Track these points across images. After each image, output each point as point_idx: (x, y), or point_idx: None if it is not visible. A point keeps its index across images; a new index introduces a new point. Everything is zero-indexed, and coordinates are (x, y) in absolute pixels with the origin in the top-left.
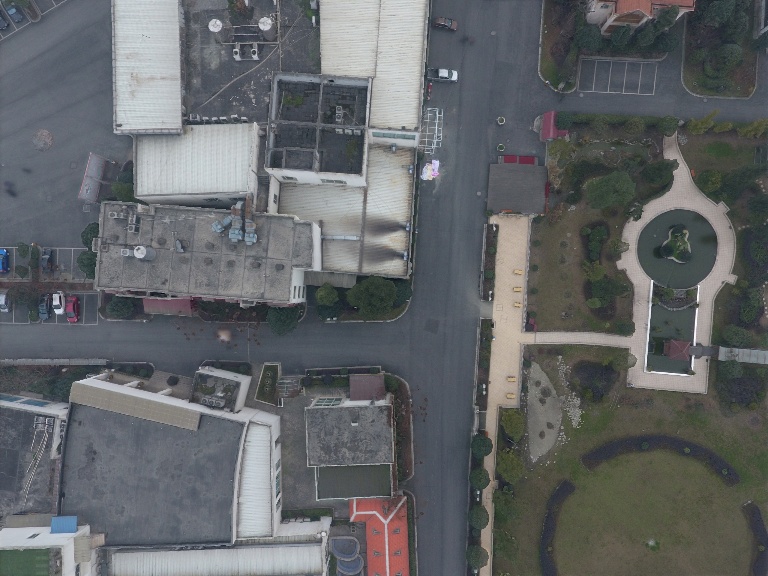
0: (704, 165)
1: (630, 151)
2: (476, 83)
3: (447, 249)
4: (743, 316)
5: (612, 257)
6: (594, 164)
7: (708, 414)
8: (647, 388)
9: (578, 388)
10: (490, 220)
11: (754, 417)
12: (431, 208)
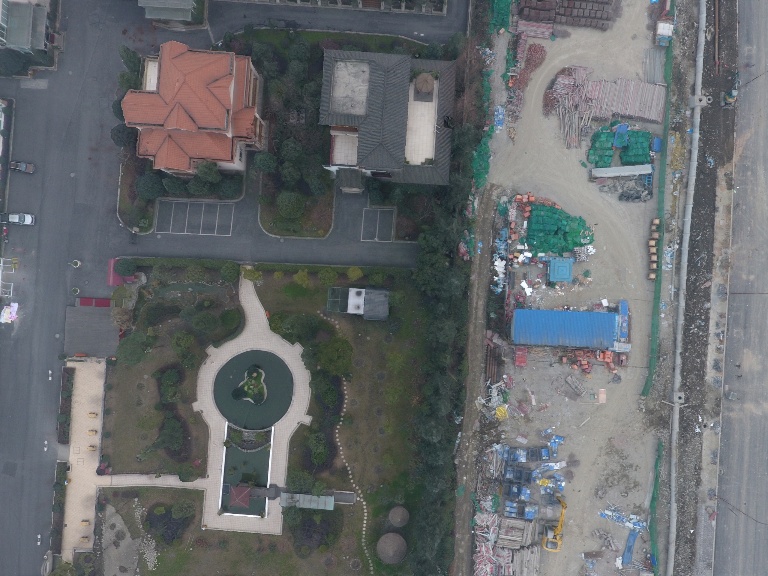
0: (281, 305)
1: (208, 292)
2: (55, 225)
3: (25, 392)
4: (313, 458)
5: (186, 399)
6: (168, 306)
7: (283, 555)
8: (222, 530)
9: (154, 530)
10: (67, 363)
11: (328, 558)
12: (10, 351)
